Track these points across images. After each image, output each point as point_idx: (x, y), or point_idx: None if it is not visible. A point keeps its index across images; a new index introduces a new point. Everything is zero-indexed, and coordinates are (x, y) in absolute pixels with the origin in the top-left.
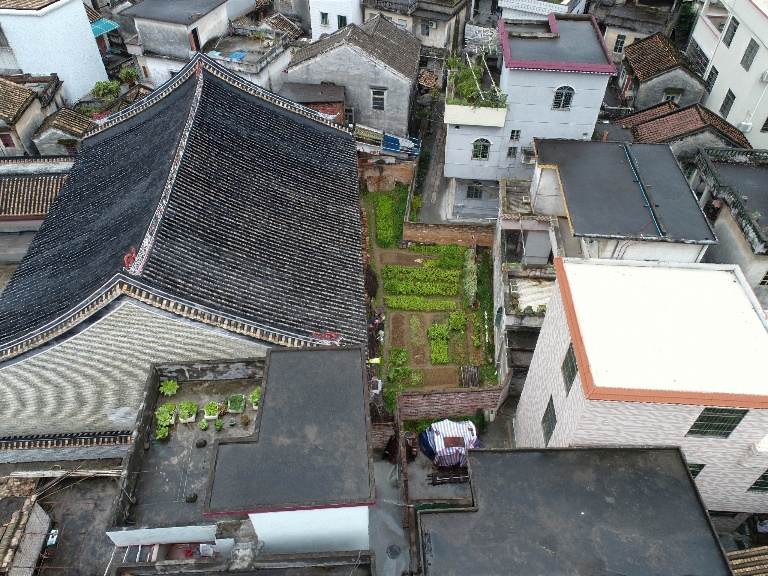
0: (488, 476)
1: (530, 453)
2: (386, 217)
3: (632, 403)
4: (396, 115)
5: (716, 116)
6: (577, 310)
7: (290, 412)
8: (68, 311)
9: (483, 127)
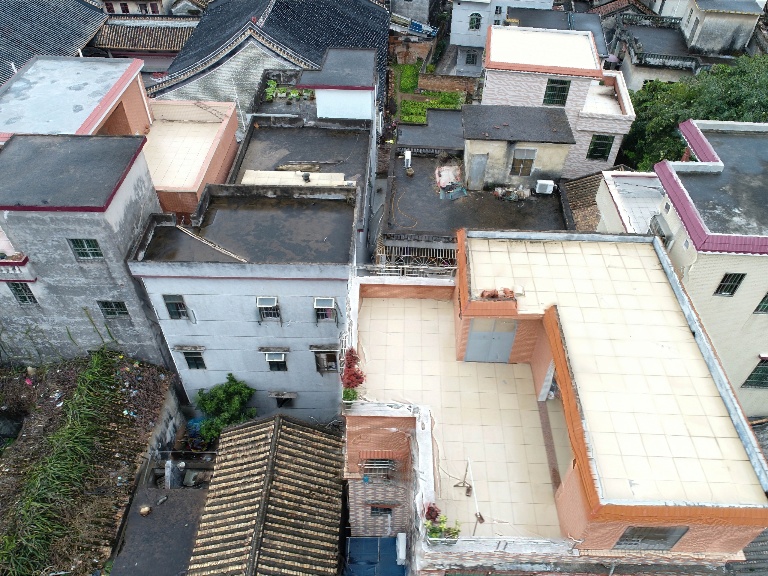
0: (436, 117)
1: (460, 112)
2: (408, 77)
3: (511, 75)
4: (421, 6)
5: (643, 5)
6: (493, 42)
7: (337, 64)
8: (219, 48)
9: (476, 4)
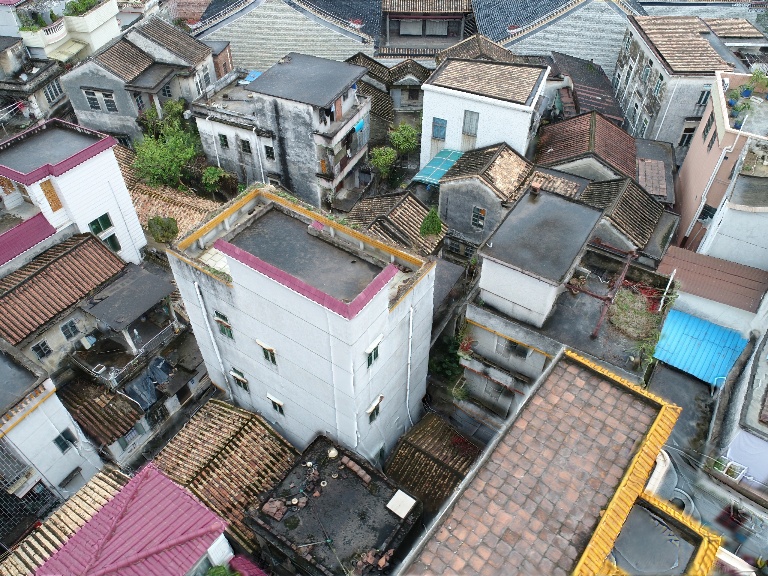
0: None
1: None
2: None
3: None
4: None
5: None
6: None
7: None
8: None
9: None
